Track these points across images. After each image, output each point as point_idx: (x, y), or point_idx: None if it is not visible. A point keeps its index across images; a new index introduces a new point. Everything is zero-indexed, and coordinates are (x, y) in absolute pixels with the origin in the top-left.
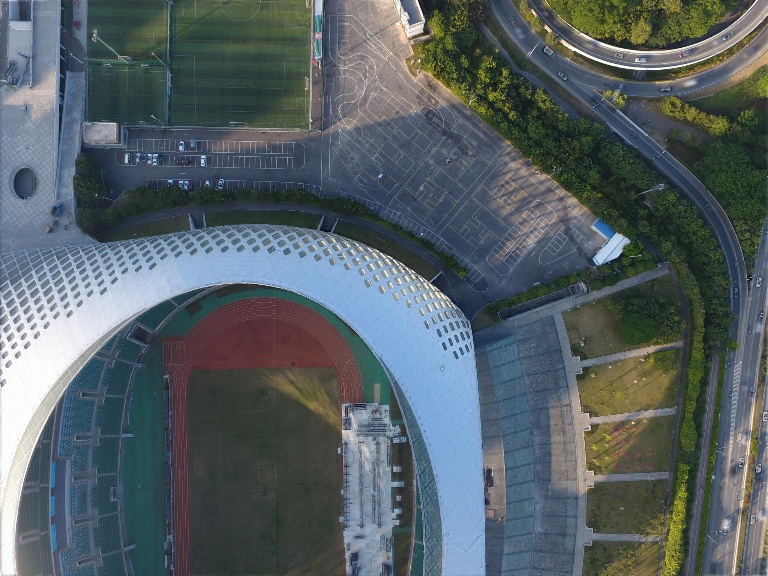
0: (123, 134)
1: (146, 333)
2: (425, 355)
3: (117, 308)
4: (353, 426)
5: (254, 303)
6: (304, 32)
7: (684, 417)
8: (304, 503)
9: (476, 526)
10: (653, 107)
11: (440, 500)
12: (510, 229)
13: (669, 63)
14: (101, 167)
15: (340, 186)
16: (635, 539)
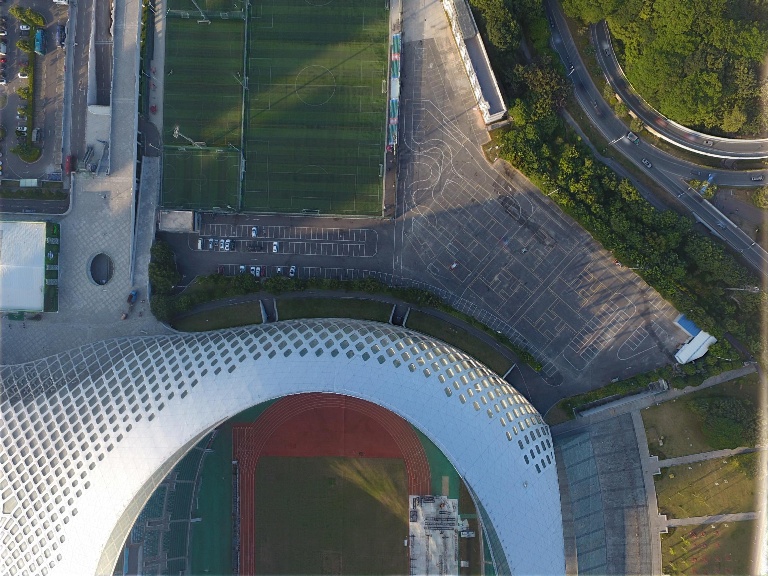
0: (197, 220)
1: None
2: (508, 471)
3: (199, 414)
4: (421, 518)
5: None
6: (379, 117)
7: None
8: None
9: None
10: (743, 196)
11: None
12: (587, 322)
13: (763, 152)
14: (174, 252)
15: (412, 275)
16: None
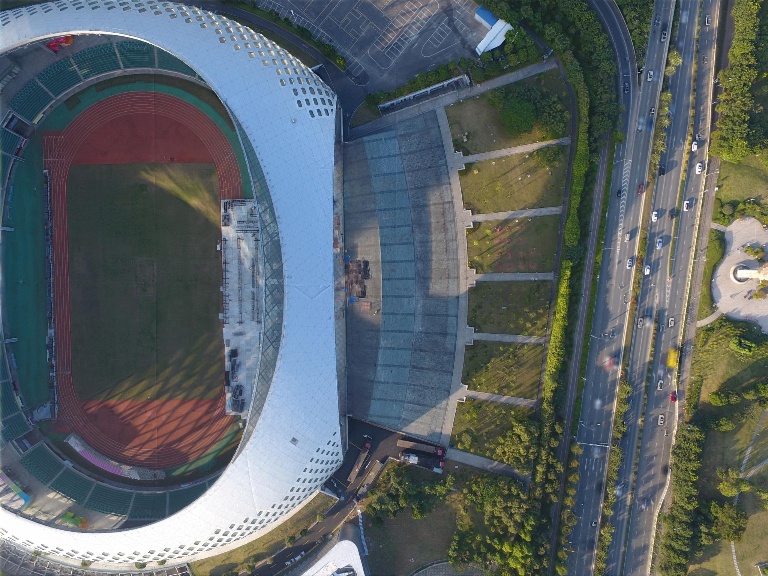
0: None
1: (25, 127)
2: (276, 106)
3: None
4: (232, 222)
5: (133, 97)
6: None
7: (569, 215)
8: (184, 299)
9: (323, 275)
10: None
11: (282, 241)
12: (392, 20)
13: None
14: None
15: None
16: (518, 340)
